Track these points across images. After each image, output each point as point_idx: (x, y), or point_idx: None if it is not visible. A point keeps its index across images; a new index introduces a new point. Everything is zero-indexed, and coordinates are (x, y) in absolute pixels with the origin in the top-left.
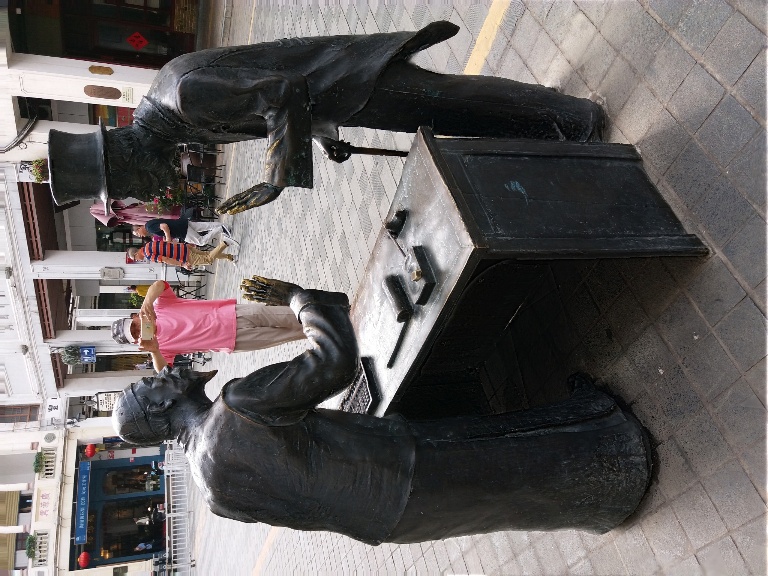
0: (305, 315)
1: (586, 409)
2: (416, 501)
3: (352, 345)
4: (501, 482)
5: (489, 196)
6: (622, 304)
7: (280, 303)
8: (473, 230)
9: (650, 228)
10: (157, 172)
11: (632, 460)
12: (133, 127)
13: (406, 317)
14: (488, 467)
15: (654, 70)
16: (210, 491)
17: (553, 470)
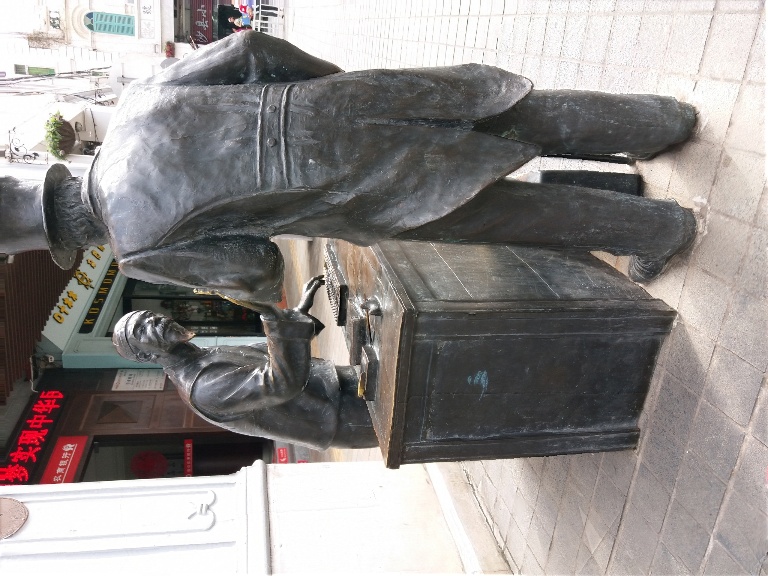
0: (269, 339)
1: None
2: None
3: (303, 377)
4: None
5: (442, 392)
6: None
7: None
8: (394, 452)
9: (599, 420)
10: None
11: None
12: None
13: None
14: None
15: (745, 307)
16: None
17: None
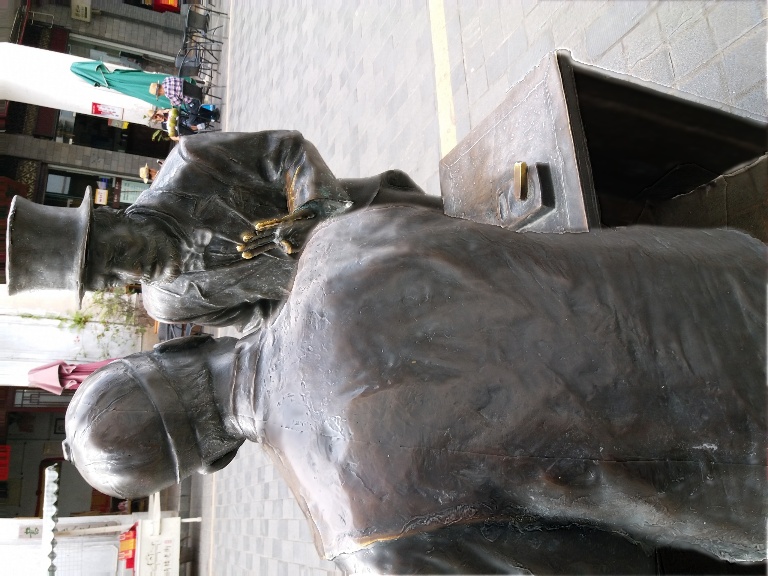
0: None
1: None
2: None
3: None
4: None
5: None
6: None
7: None
8: None
9: None
10: None
11: None
12: None
13: None
14: None
15: None
16: (341, 435)
17: None
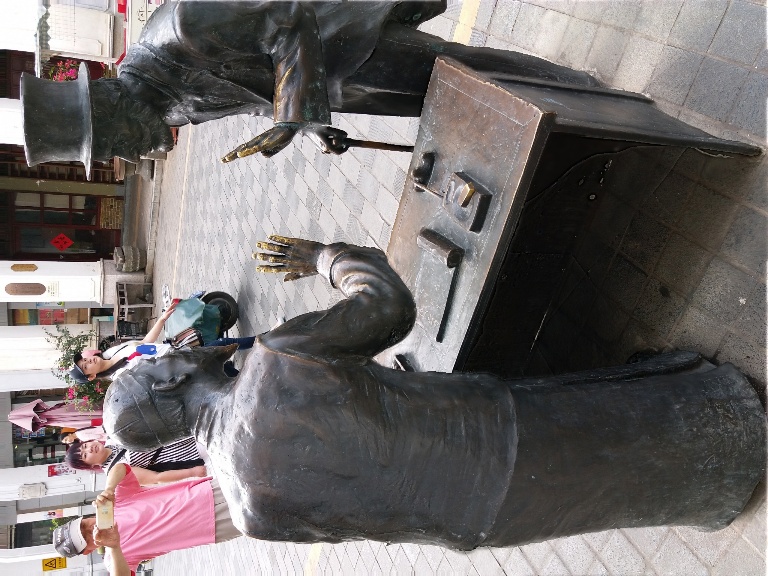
0: (339, 266)
1: (672, 361)
2: (525, 456)
3: (404, 286)
4: (616, 430)
5: None
6: (672, 253)
7: (303, 268)
8: (534, 104)
9: None
10: (148, 123)
11: (745, 404)
12: (118, 79)
13: (456, 260)
14: (597, 411)
15: (644, 19)
16: (246, 492)
17: (668, 416)
